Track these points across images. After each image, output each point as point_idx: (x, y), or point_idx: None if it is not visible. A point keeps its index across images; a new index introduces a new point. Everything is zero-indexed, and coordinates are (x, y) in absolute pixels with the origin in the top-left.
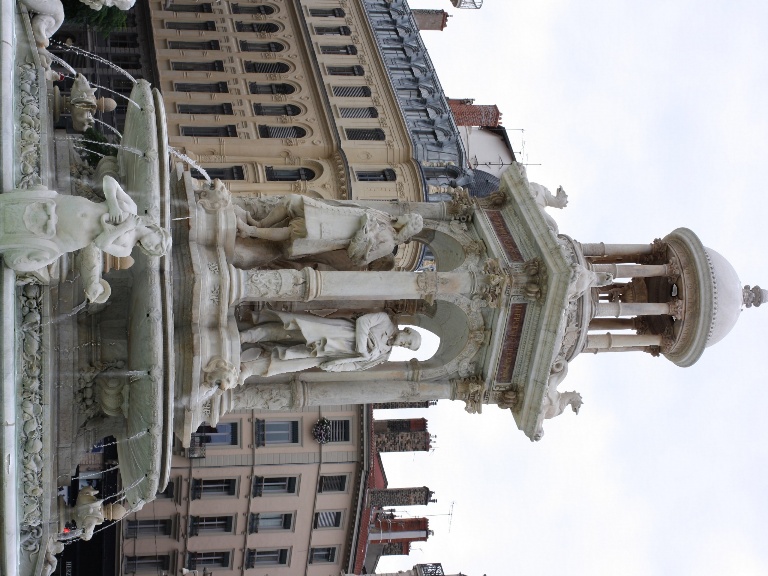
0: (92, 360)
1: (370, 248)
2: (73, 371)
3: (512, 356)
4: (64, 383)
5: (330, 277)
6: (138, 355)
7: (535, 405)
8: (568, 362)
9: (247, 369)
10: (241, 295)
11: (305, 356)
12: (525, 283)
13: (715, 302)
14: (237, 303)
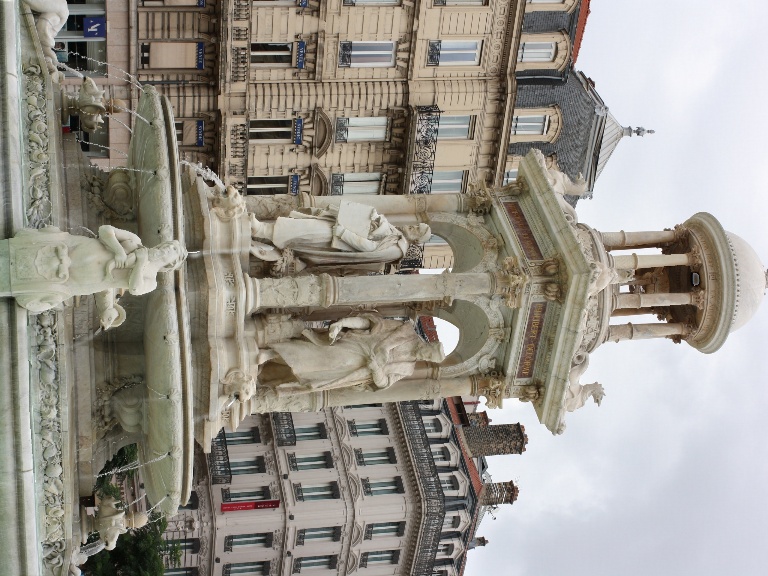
0: None
1: None
2: None
3: (531, 240)
4: (70, 166)
5: None
6: None
7: (573, 246)
8: None
9: None
10: None
11: (313, 216)
12: None
13: None
14: None
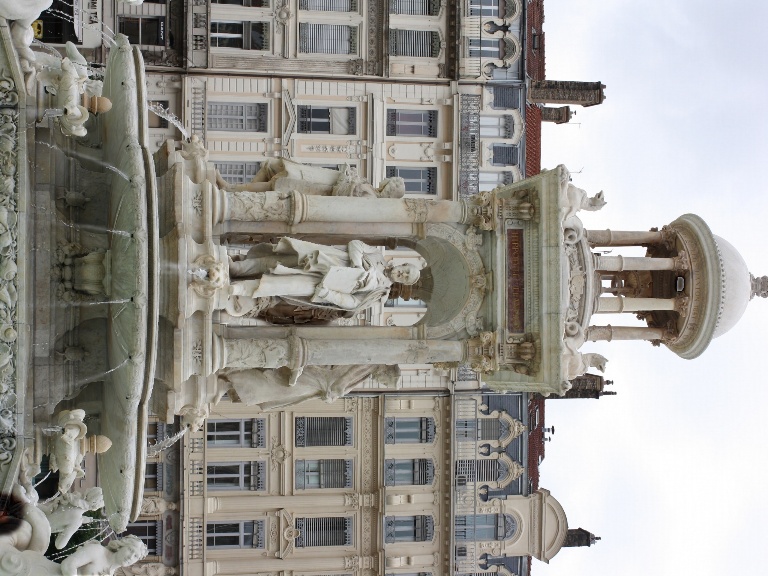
0: (71, 239)
1: (353, 188)
2: (50, 234)
3: (519, 298)
4: (41, 246)
5: (315, 196)
6: (119, 189)
7: (554, 344)
8: (582, 328)
9: (237, 284)
10: (225, 208)
11: (298, 271)
12: (516, 204)
13: (719, 254)
14: (222, 232)
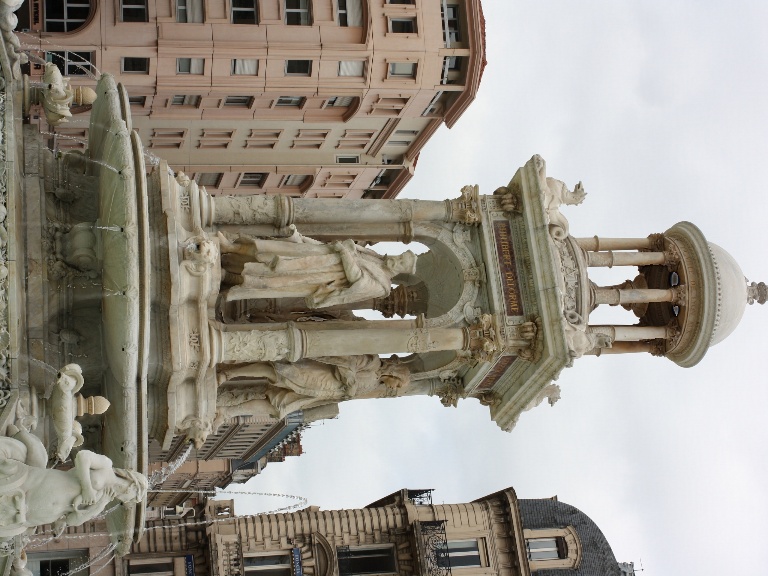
0: None
1: None
2: None
3: None
4: None
5: None
6: None
7: None
8: None
9: None
10: None
11: None
12: None
13: None
14: None
